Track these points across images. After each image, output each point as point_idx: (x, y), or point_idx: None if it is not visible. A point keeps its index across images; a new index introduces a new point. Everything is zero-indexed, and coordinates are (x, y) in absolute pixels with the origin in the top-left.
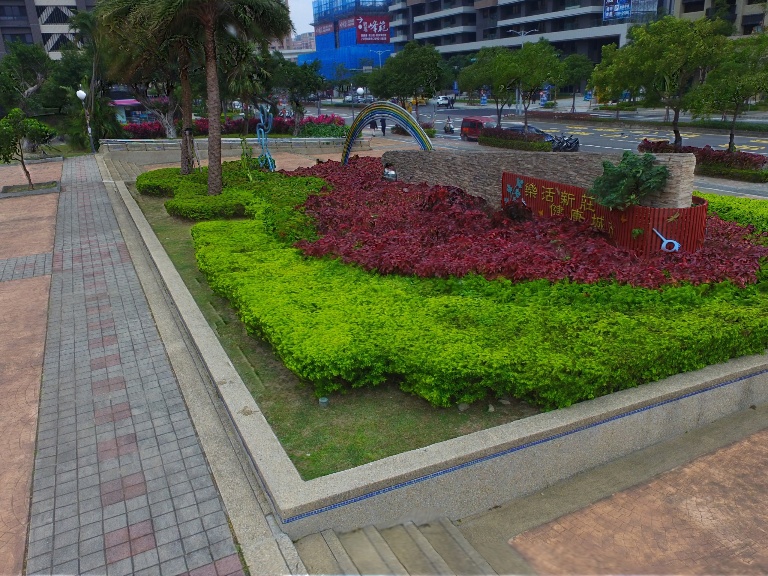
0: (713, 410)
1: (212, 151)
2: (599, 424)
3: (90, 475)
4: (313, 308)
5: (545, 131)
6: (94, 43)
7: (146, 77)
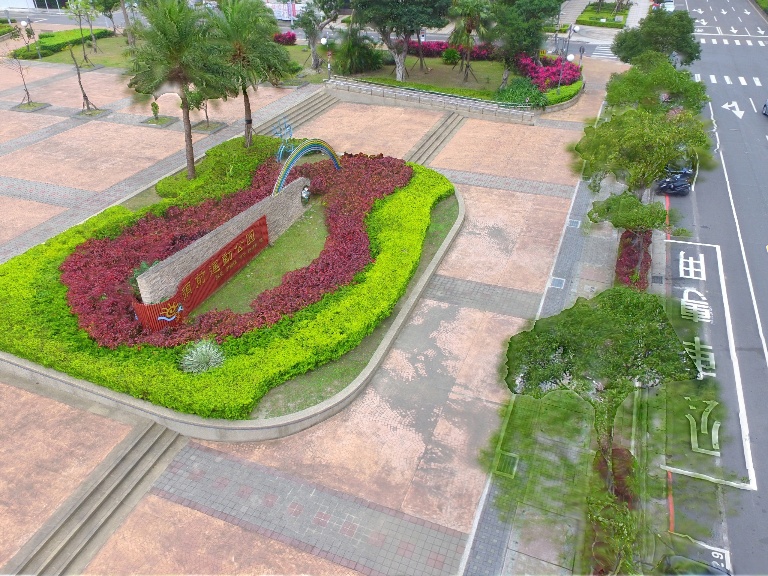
0: None
1: (187, 156)
2: None
3: None
4: (6, 274)
5: None
6: None
7: (385, 25)
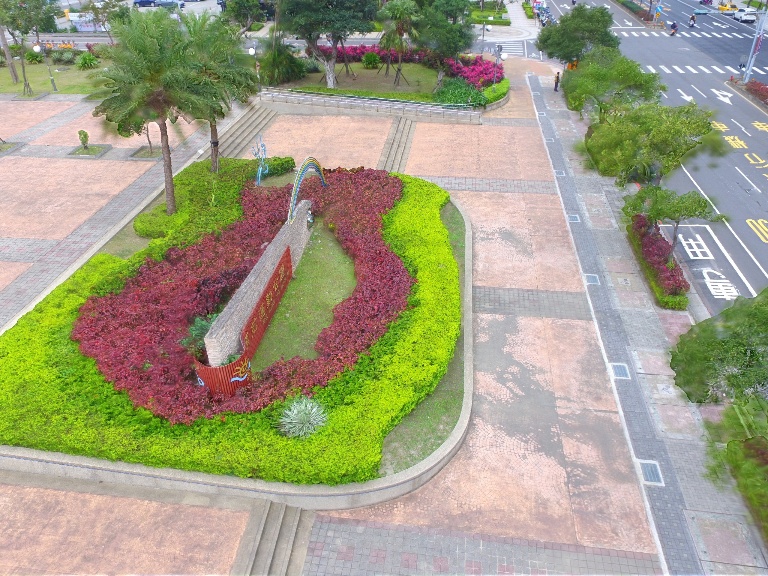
0: (74, 474)
1: (166, 189)
2: (5, 457)
3: None
4: (6, 355)
5: (711, 126)
6: (277, 3)
7: None
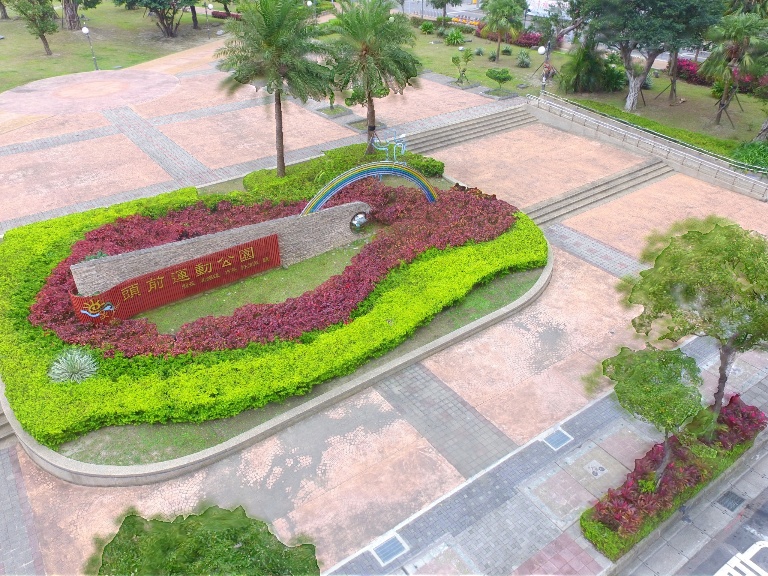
0: None
1: None
2: None
3: (7, 225)
4: None
5: None
6: None
7: None
